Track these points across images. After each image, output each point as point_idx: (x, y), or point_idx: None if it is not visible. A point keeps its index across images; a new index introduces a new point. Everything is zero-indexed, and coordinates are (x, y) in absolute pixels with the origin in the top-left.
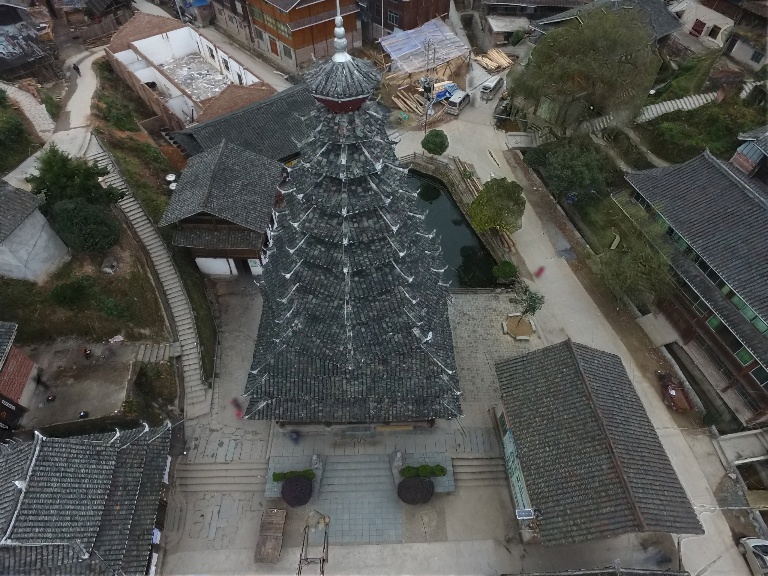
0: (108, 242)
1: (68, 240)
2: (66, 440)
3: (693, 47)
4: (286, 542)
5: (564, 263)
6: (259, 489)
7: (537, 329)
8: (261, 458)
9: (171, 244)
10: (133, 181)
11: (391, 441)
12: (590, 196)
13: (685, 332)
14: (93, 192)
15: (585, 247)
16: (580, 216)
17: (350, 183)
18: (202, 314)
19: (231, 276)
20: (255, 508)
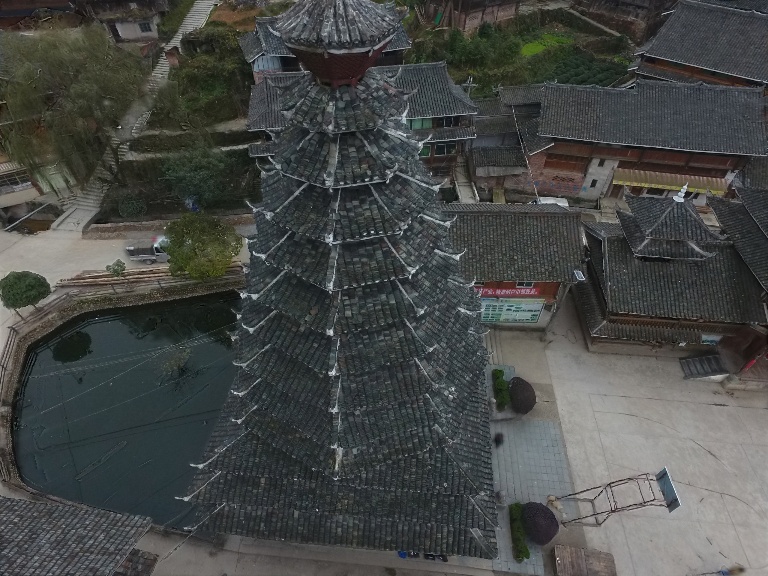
0: None
1: None
2: None
3: None
4: None
5: None
6: None
7: None
8: None
9: None
10: None
11: None
12: None
13: None
14: None
15: None
16: (222, 209)
17: None
18: None
19: None
20: None
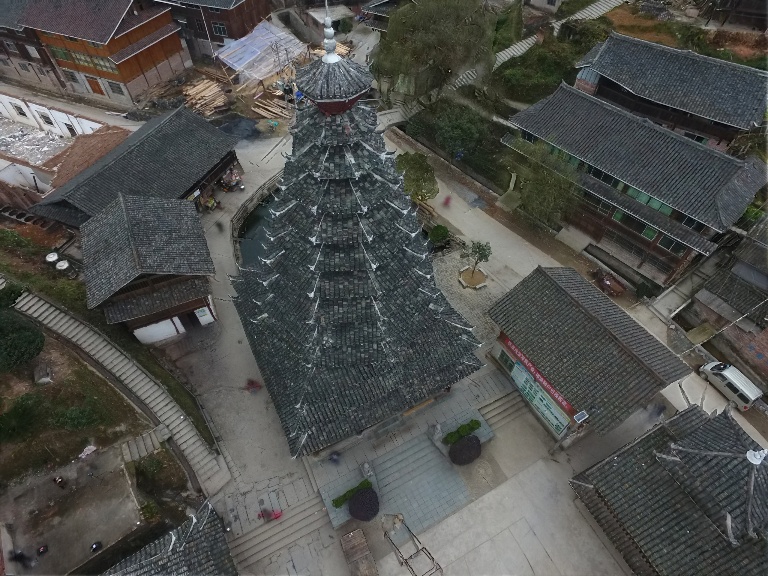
0: (35, 348)
1: None
2: (122, 572)
3: (496, 3)
4: (374, 557)
5: (480, 211)
6: (322, 524)
7: (488, 274)
8: (309, 495)
9: (99, 326)
10: (13, 274)
11: (421, 420)
12: None
13: (595, 233)
14: None
15: (489, 193)
16: (472, 168)
17: (357, 181)
18: (173, 385)
19: (179, 336)
20: (328, 543)
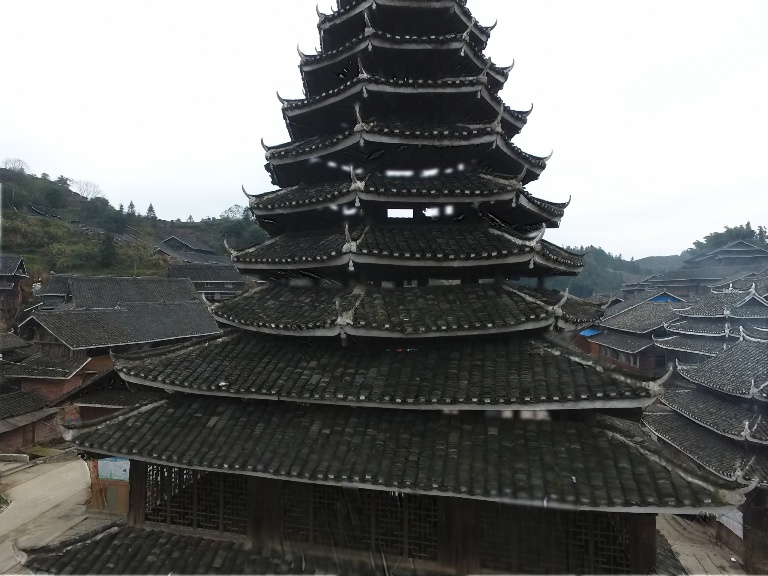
0: None
1: None
2: None
3: None
4: None
5: None
6: None
7: None
8: None
9: None
10: None
11: None
12: None
13: None
14: None
15: None
16: None
17: None
18: None
19: None
20: None
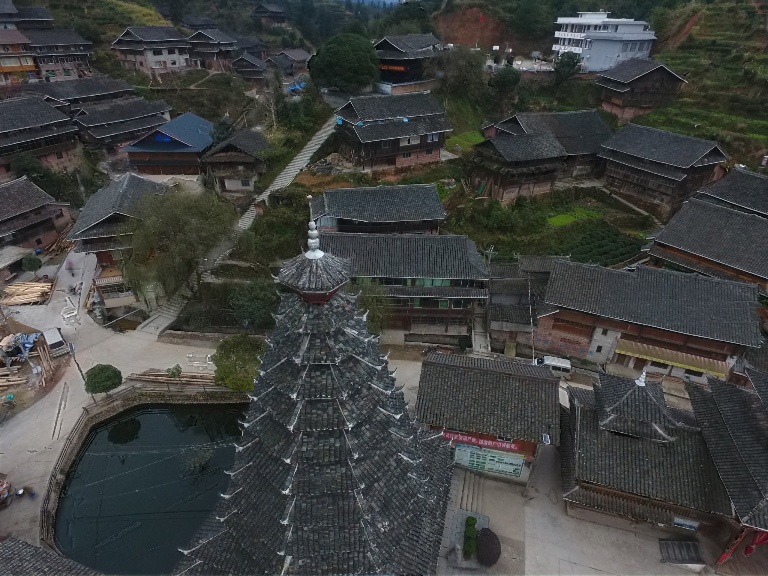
0: None
1: None
2: None
3: None
4: None
5: None
6: None
7: None
8: None
9: None
10: None
11: None
12: None
13: (404, 325)
14: None
15: None
16: (270, 329)
17: None
18: None
19: None
20: None
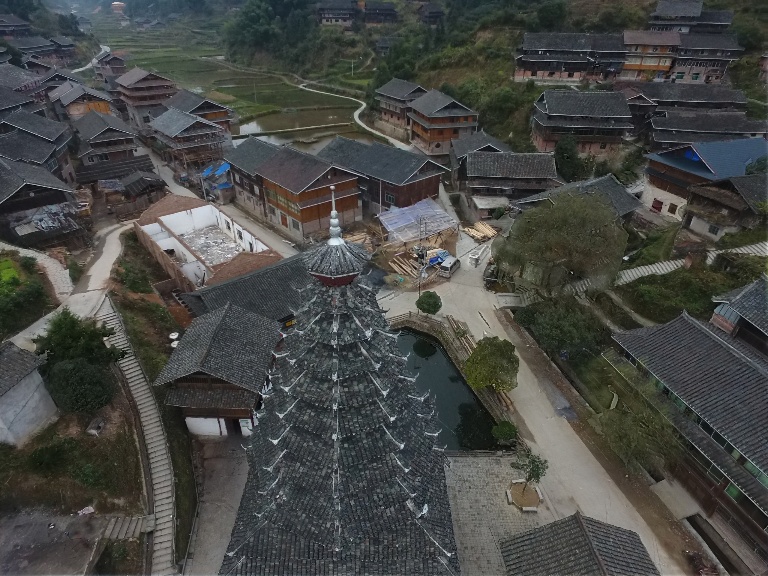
0: (99, 402)
1: (59, 401)
2: None
3: (655, 221)
4: None
5: (565, 423)
6: None
7: (544, 498)
8: None
9: None
10: (137, 340)
11: None
12: (583, 353)
13: (705, 502)
14: (95, 352)
15: (584, 405)
16: (575, 373)
17: (341, 349)
18: (184, 481)
19: (220, 437)
20: None
